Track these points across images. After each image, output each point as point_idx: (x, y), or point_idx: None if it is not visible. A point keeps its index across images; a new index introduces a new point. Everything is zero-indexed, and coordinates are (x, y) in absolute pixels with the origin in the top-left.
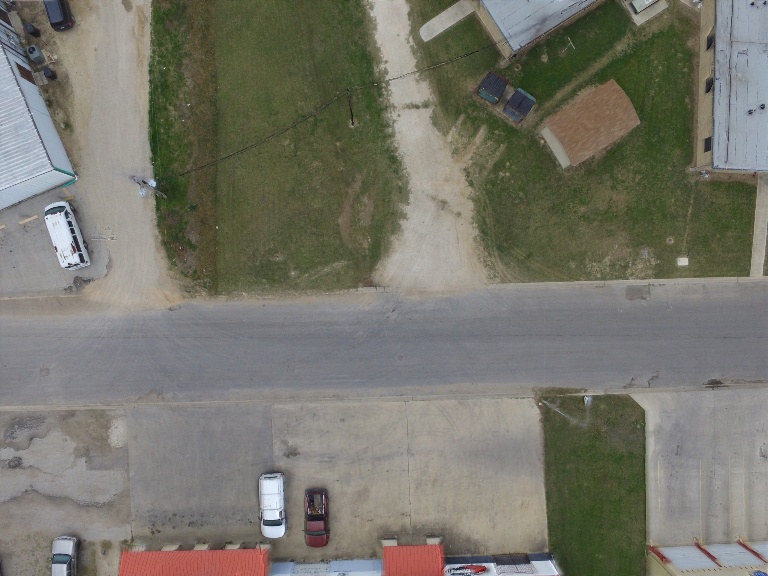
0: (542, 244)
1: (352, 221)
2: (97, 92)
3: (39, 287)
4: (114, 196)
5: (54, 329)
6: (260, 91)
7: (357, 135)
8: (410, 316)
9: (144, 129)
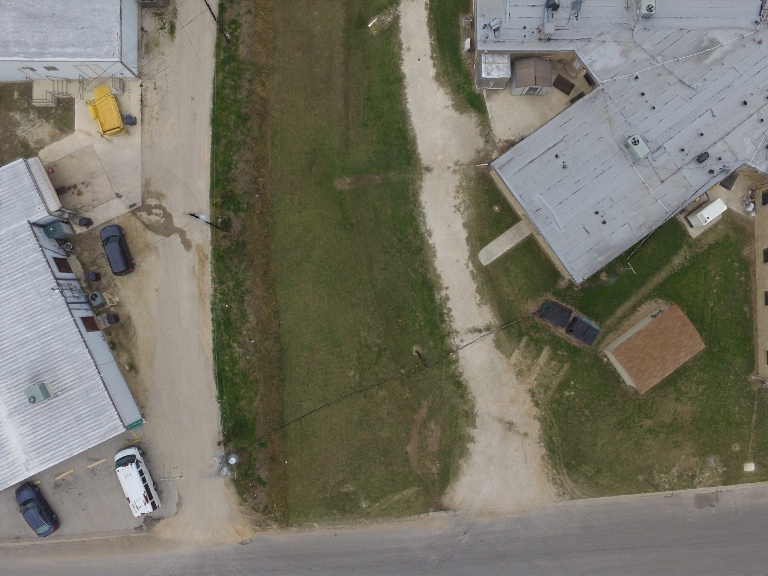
0: (610, 460)
1: (420, 447)
2: (160, 332)
3: (109, 527)
4: (181, 436)
5: (126, 568)
6: (323, 323)
7: (421, 362)
8: (482, 538)
9: (209, 367)
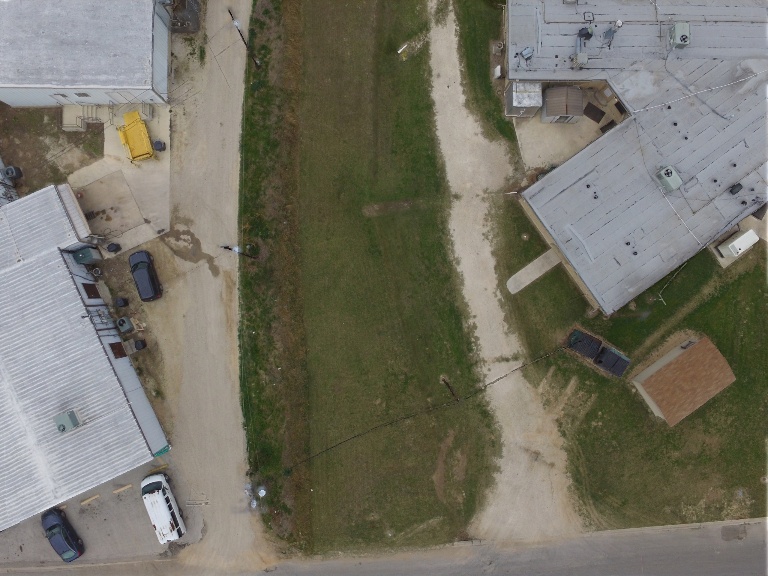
0: (637, 491)
1: (446, 476)
2: (187, 358)
3: (134, 553)
4: (207, 462)
5: None
6: (350, 351)
7: (448, 391)
8: (507, 568)
9: (235, 394)
